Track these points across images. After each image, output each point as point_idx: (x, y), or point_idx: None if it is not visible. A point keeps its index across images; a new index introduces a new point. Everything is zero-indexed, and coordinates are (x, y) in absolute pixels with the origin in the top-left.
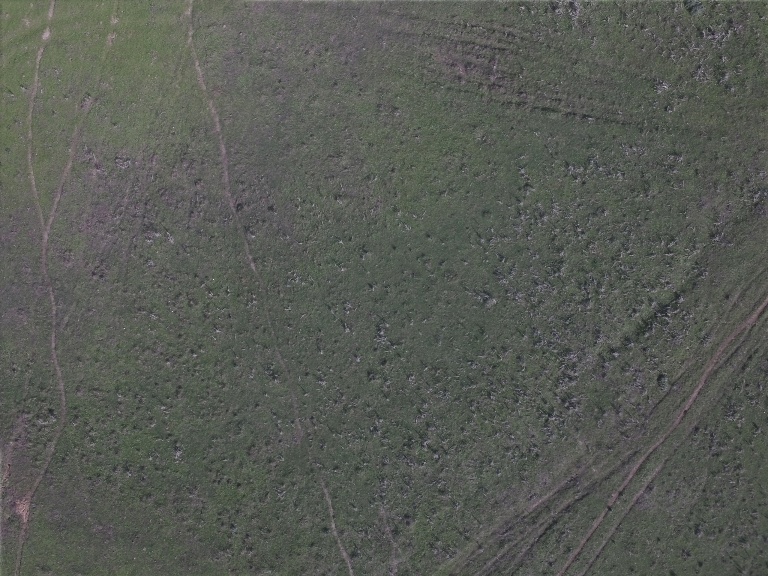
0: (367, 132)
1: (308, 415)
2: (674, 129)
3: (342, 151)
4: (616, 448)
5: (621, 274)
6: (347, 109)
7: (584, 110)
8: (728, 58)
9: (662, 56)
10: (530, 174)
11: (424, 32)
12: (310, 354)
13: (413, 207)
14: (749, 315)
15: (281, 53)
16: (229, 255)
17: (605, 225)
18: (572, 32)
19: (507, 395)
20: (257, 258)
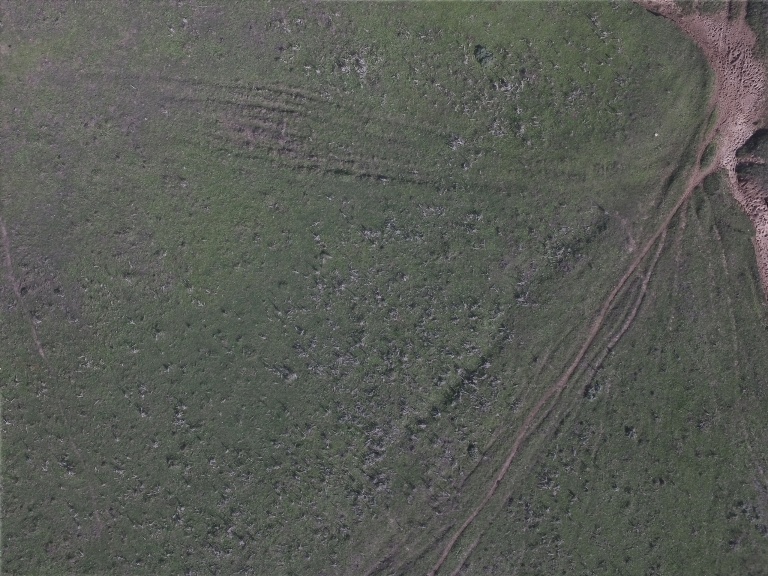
0: (154, 205)
1: (107, 506)
2: (473, 186)
3: (129, 227)
4: (428, 524)
5: (424, 341)
6: (131, 183)
7: (379, 171)
8: (523, 110)
9: (455, 111)
10: (326, 241)
11: (208, 98)
12: (106, 442)
13: (206, 282)
14: (559, 377)
15: (58, 128)
16: (15, 342)
17: (406, 290)
18: (361, 90)
19: (313, 474)
20: (45, 344)
